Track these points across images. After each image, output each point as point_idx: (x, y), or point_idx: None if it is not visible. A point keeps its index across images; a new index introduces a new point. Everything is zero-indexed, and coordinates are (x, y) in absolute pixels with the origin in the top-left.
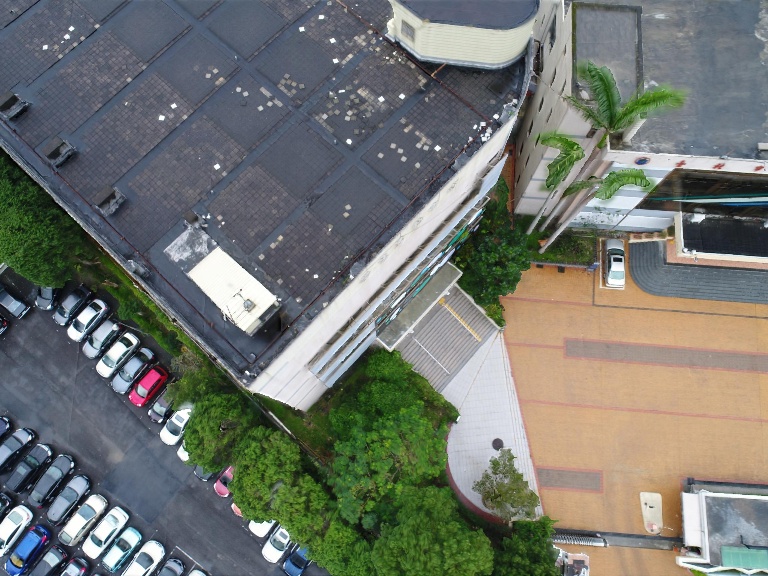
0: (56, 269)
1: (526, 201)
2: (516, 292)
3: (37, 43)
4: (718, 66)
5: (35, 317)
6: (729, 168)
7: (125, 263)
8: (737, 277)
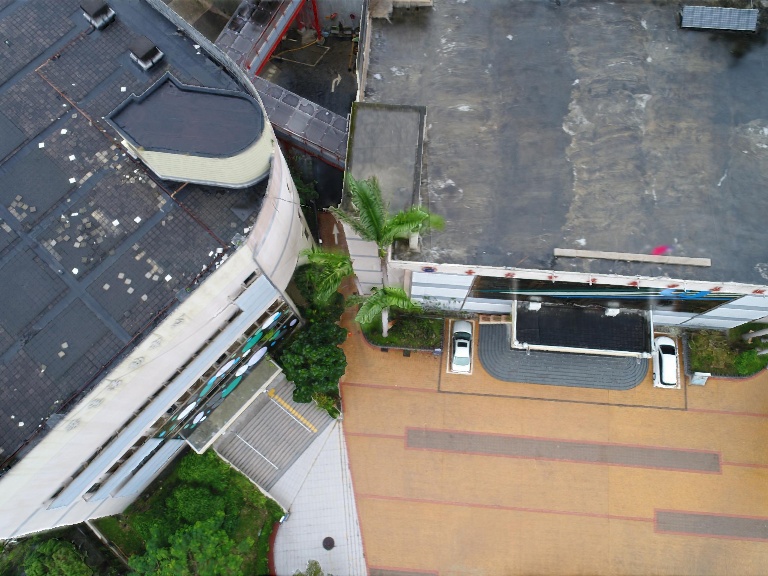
0: None
1: (363, 285)
2: (358, 378)
3: None
4: (520, 163)
5: None
6: (523, 276)
7: None
8: (587, 363)
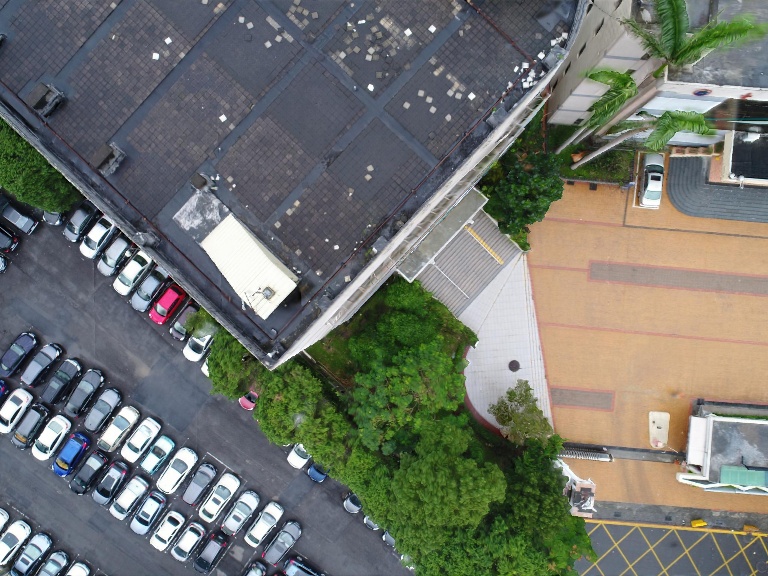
0: (59, 194)
1: (562, 113)
2: None
3: None
4: None
5: (45, 232)
6: None
7: (133, 235)
8: None
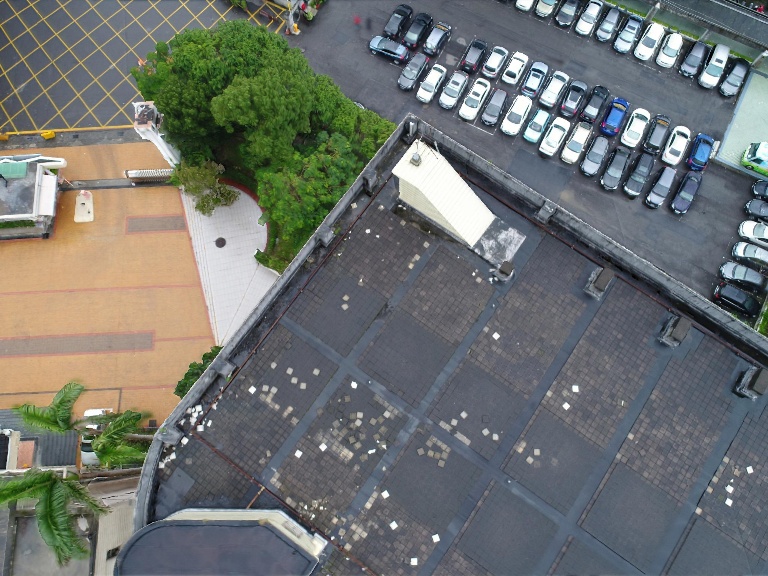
0: None
1: None
2: None
3: (763, 475)
4: None
5: None
6: None
7: (557, 210)
8: None
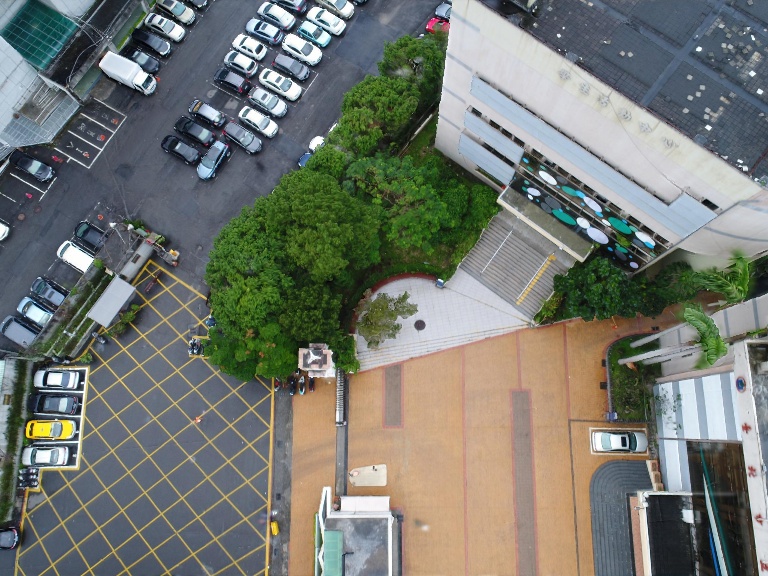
0: None
1: (675, 333)
2: (572, 339)
3: None
4: None
5: None
6: (753, 487)
7: None
8: None
